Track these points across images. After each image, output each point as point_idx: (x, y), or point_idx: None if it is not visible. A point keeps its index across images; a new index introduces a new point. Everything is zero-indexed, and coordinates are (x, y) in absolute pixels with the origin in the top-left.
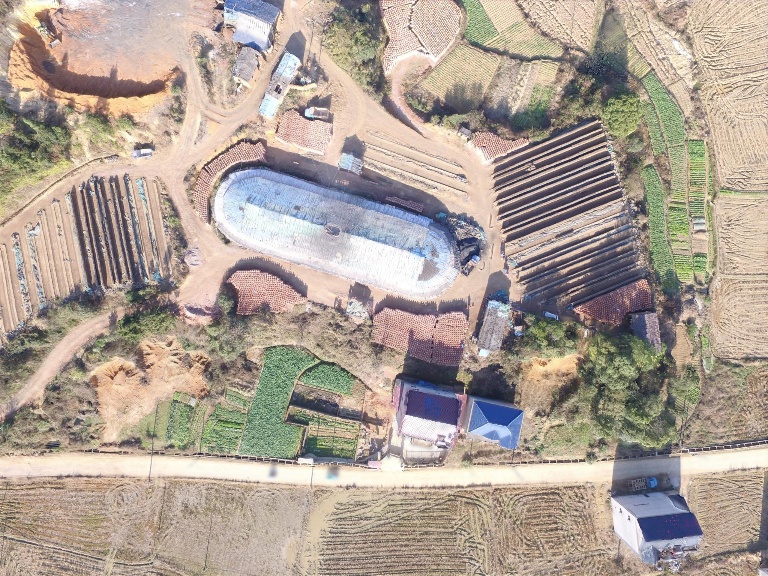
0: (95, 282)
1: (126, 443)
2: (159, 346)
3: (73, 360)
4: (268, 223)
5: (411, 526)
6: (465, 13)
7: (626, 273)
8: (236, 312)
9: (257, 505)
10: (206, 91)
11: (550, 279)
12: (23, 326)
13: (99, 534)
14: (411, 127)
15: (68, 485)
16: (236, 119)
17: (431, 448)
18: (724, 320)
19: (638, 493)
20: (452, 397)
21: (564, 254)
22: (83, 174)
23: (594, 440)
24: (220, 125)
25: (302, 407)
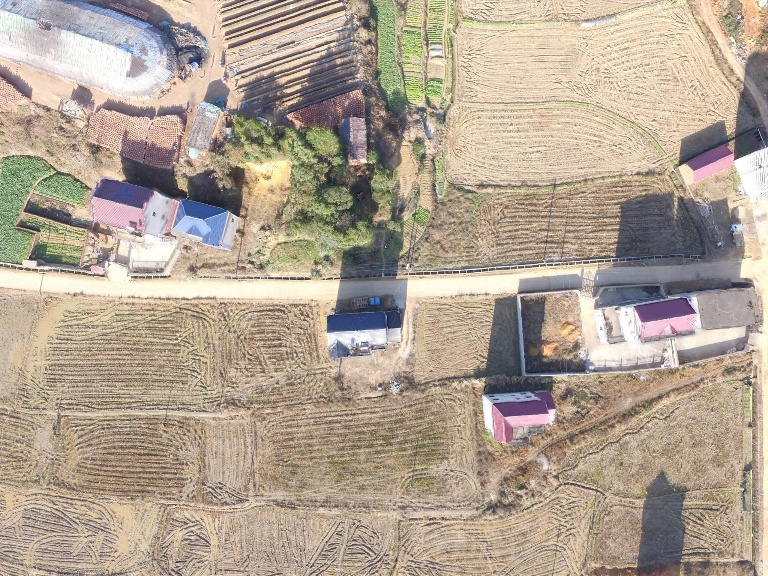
0: None
1: None
2: None
3: None
4: None
5: (136, 336)
6: None
7: (345, 85)
8: None
9: None
10: None
11: (268, 88)
12: None
13: None
14: None
15: None
16: None
17: (157, 258)
18: (460, 147)
19: (360, 311)
20: None
21: (282, 64)
22: None
23: (319, 258)
24: None
25: (34, 214)
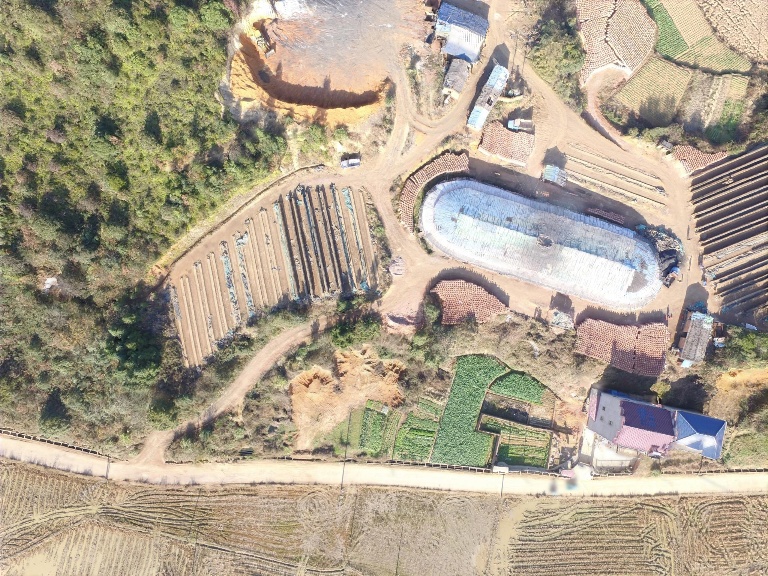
0: (305, 291)
1: (320, 450)
2: (353, 354)
3: (274, 368)
4: (481, 234)
5: (599, 534)
6: (657, 27)
7: None
8: (441, 322)
9: (447, 513)
10: (415, 102)
11: (747, 291)
12: (233, 334)
13: (291, 541)
14: (609, 139)
15: (260, 492)
16: (442, 130)
17: (621, 457)
18: None
19: None
20: (661, 408)
21: (761, 266)
22: (290, 183)
23: None
24: (426, 136)
25: (494, 416)
